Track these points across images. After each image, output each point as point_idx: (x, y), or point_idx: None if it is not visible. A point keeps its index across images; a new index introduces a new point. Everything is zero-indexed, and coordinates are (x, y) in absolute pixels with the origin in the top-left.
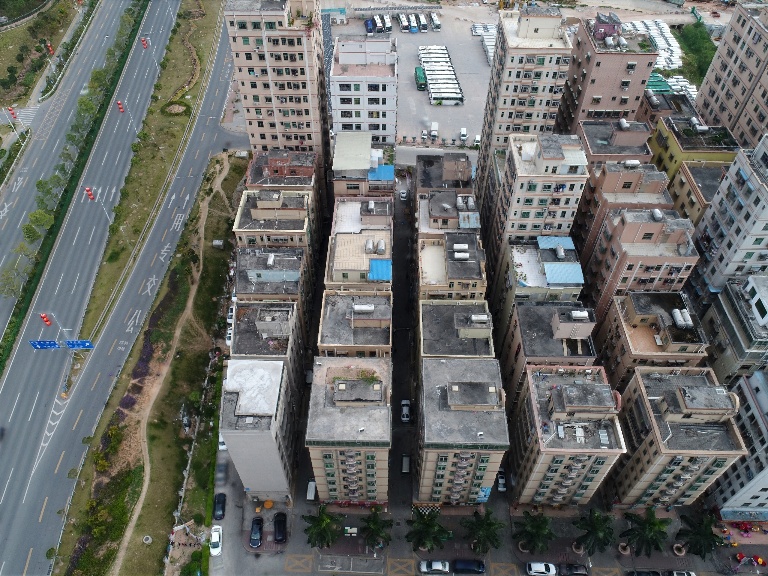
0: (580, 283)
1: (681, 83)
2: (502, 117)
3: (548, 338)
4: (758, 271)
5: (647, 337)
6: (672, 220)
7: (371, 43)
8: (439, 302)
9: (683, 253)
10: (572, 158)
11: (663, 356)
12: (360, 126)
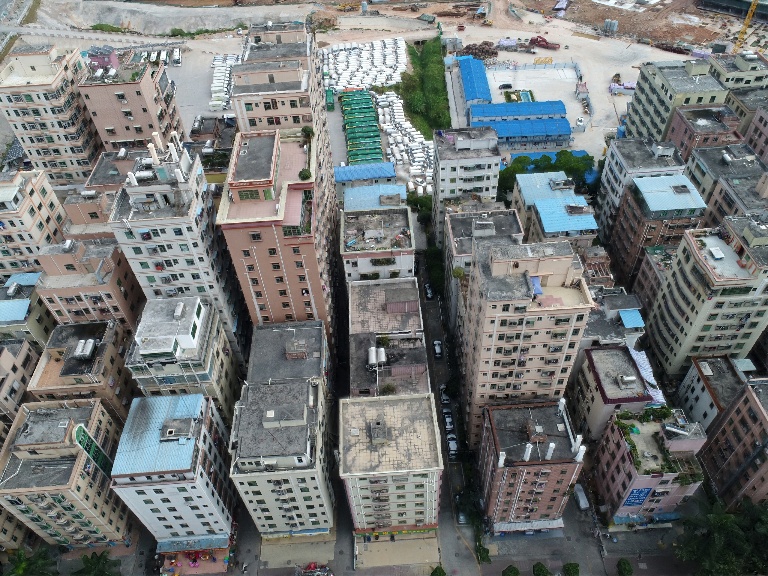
0: (19, 320)
1: (389, 99)
2: (31, 155)
3: None
4: (178, 293)
5: None
6: (96, 249)
7: None
8: None
9: (104, 281)
10: (0, 195)
11: (62, 389)
12: None
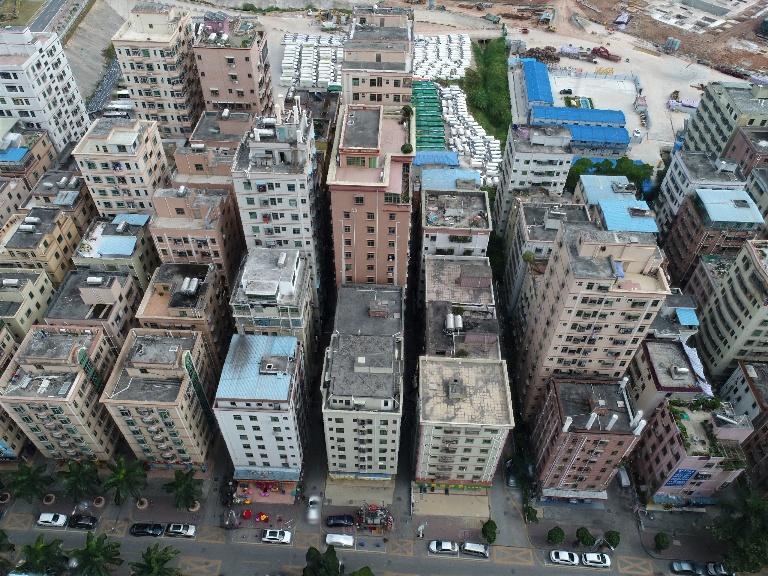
0: (127, 254)
1: (453, 92)
2: (137, 107)
3: (80, 303)
4: (277, 245)
5: (166, 304)
6: (205, 197)
7: (6, 35)
8: (1, 270)
9: None
10: (122, 139)
11: (167, 320)
12: (11, 112)
